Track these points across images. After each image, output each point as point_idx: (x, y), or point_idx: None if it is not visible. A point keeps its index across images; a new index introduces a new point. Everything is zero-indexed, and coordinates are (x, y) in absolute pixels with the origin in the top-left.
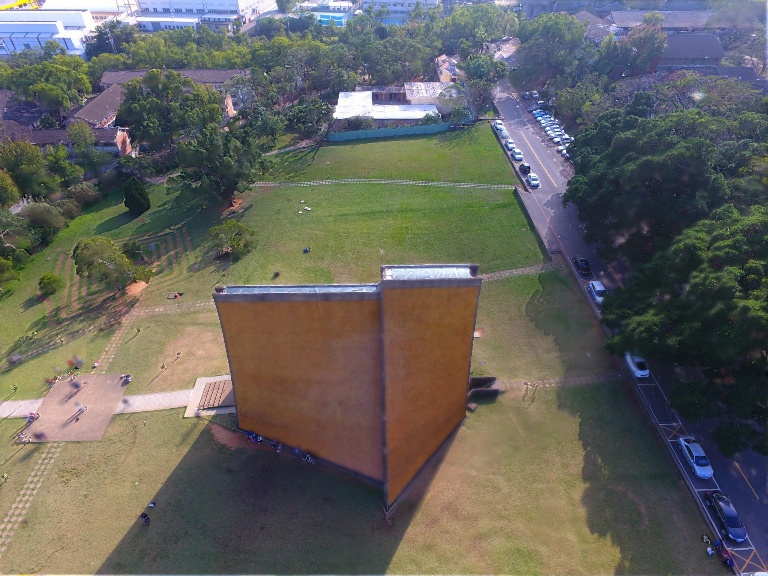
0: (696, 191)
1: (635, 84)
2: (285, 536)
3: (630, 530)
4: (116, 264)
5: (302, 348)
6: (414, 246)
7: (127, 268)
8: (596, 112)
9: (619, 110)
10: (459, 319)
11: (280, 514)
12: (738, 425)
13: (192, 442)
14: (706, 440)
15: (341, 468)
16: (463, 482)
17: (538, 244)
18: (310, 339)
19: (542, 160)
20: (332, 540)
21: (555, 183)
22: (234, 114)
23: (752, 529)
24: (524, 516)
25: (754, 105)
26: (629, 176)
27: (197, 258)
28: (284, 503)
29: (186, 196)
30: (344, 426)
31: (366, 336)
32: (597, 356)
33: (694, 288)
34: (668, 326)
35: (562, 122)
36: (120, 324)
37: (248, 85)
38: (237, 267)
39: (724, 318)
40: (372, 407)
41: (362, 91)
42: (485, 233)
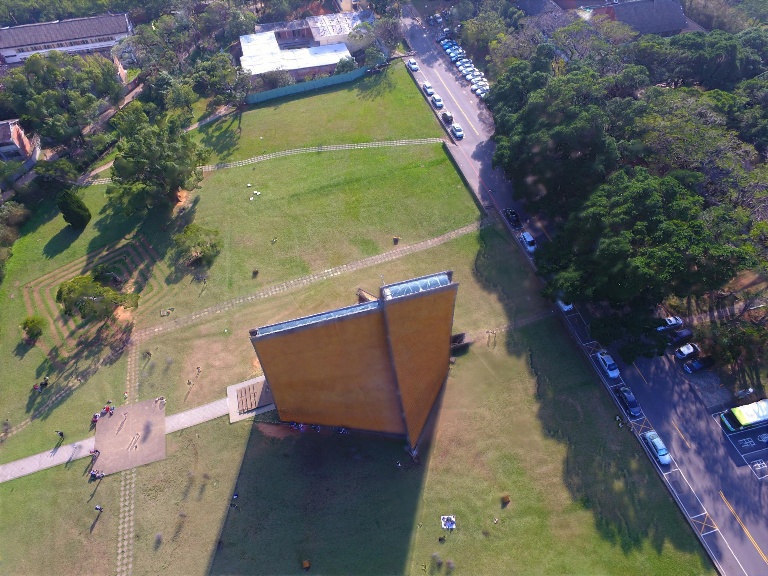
0: (596, 153)
1: (535, 26)
2: (346, 491)
3: (572, 424)
4: (104, 298)
5: (325, 357)
6: (369, 220)
7: (113, 297)
8: (502, 50)
9: (526, 62)
10: (443, 311)
11: (337, 477)
12: (633, 341)
13: (246, 441)
14: (613, 349)
15: (370, 432)
16: (459, 419)
17: (474, 200)
18: (331, 349)
19: (460, 104)
20: (380, 484)
21: (476, 130)
22: (125, 74)
23: (644, 405)
24: (504, 432)
25: (633, 49)
26: (545, 147)
27: (170, 268)
28: (337, 468)
29: (135, 205)
30: (367, 403)
31: (374, 338)
32: (535, 298)
33: (602, 252)
34: (585, 278)
35: (470, 52)
36: (128, 351)
37: (141, 48)
38: (214, 271)
39: (623, 274)
40: (386, 386)
41: (263, 31)
42: (427, 195)
